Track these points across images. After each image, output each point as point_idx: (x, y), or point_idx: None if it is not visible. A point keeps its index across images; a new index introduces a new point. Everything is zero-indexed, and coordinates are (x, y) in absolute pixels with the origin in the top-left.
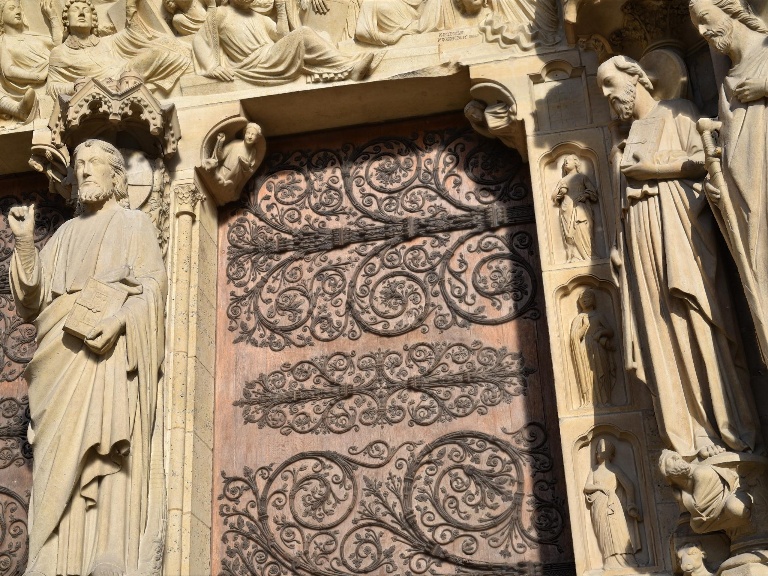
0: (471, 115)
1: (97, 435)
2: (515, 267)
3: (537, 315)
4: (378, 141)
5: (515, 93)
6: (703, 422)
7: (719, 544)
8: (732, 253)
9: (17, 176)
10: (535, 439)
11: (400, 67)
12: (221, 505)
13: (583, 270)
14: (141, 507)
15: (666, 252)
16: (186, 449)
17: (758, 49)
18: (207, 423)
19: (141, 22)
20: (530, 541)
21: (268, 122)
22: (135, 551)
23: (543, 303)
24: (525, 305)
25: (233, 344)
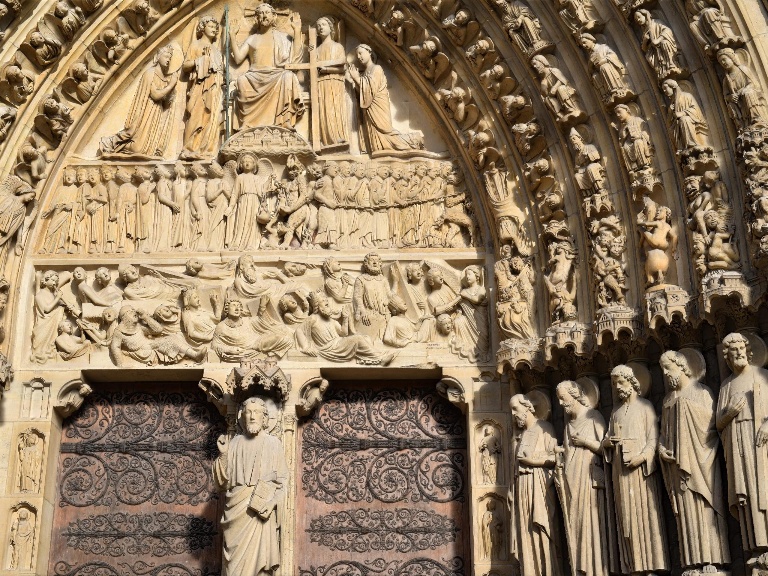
0: (440, 390)
1: (265, 562)
2: (454, 472)
3: (463, 500)
4: (386, 390)
5: (465, 387)
6: None
7: None
8: None
9: (181, 382)
10: (458, 565)
11: (406, 361)
12: None
13: (492, 490)
14: None
15: (534, 503)
16: (290, 559)
17: (584, 417)
18: (294, 542)
19: (267, 314)
20: None
21: (330, 375)
22: None
23: (467, 494)
24: (458, 494)
25: (305, 497)
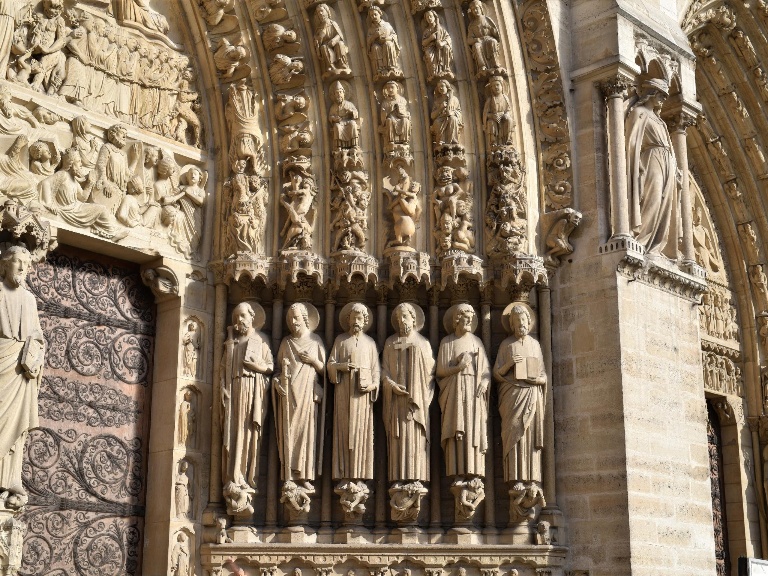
0: (149, 276)
1: None
2: (142, 357)
3: (147, 385)
4: (92, 262)
5: (180, 281)
6: (244, 473)
7: (228, 518)
8: (275, 413)
9: None
10: (137, 446)
11: (133, 242)
12: None
13: (192, 382)
14: None
15: (255, 405)
16: None
17: (309, 338)
18: None
19: (18, 157)
20: (128, 493)
21: None
22: None
23: (150, 379)
24: (143, 378)
25: None
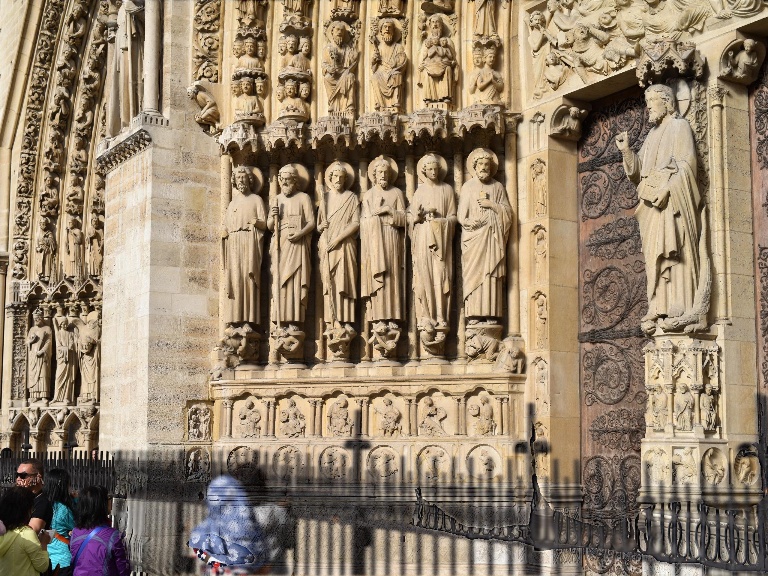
0: None
1: (661, 250)
2: None
3: None
4: None
5: None
6: None
7: None
8: None
9: None
10: None
11: None
12: (759, 263)
13: None
14: (693, 278)
15: None
16: (727, 240)
17: None
18: (745, 220)
19: None
20: None
21: (762, 31)
22: (690, 300)
23: None
24: None
25: (760, 170)
